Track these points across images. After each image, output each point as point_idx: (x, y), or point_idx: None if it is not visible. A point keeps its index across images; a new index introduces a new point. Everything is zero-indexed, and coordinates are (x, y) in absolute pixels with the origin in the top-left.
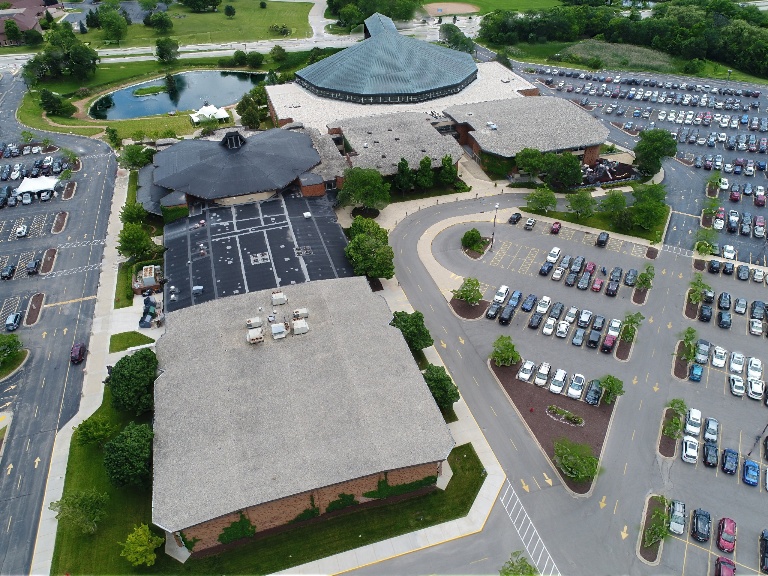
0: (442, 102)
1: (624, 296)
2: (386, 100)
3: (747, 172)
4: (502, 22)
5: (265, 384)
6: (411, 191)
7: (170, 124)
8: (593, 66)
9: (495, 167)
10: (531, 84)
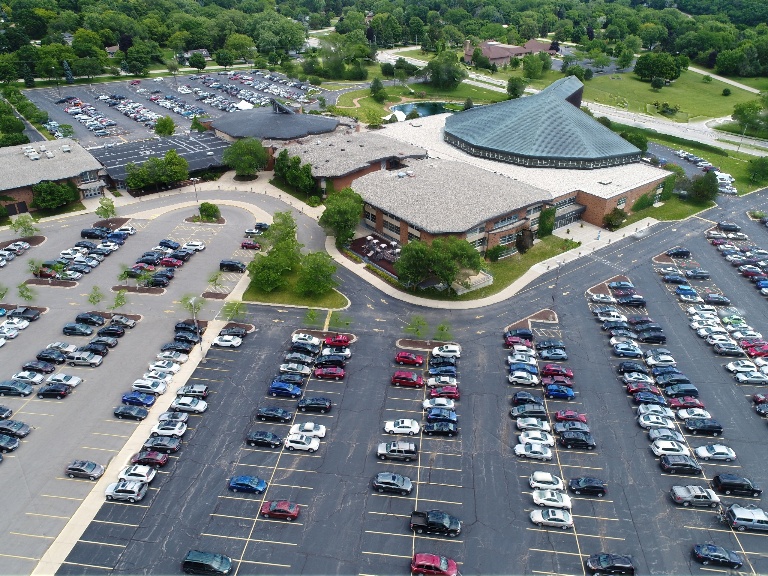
0: (490, 164)
1: None
2: (457, 144)
3: None
4: None
5: None
6: None
7: (379, 117)
8: None
9: None
10: (615, 194)
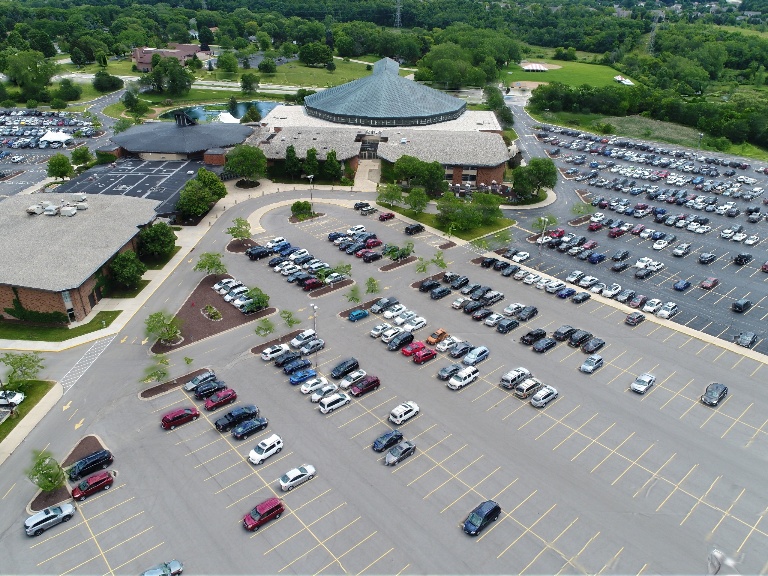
0: None
1: (377, 264)
2: (354, 121)
3: (635, 213)
4: (550, 91)
5: (5, 233)
6: (304, 179)
7: None
8: (603, 131)
9: (387, 173)
10: (500, 127)
